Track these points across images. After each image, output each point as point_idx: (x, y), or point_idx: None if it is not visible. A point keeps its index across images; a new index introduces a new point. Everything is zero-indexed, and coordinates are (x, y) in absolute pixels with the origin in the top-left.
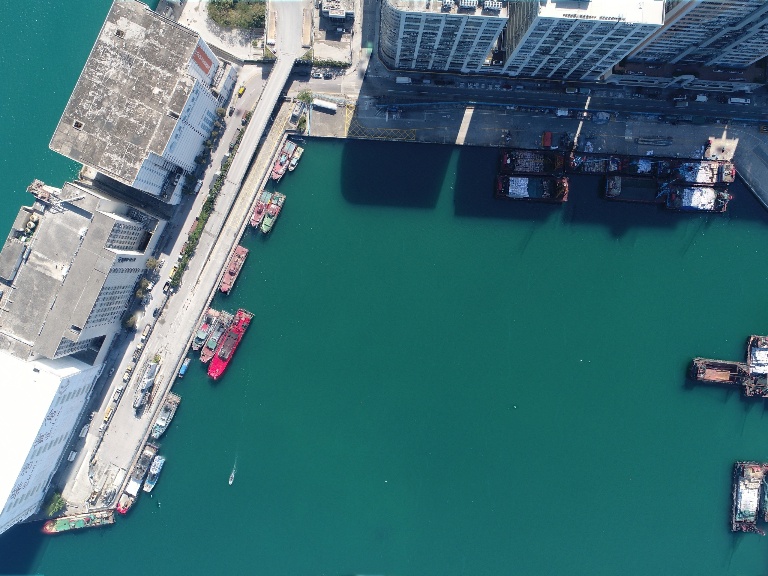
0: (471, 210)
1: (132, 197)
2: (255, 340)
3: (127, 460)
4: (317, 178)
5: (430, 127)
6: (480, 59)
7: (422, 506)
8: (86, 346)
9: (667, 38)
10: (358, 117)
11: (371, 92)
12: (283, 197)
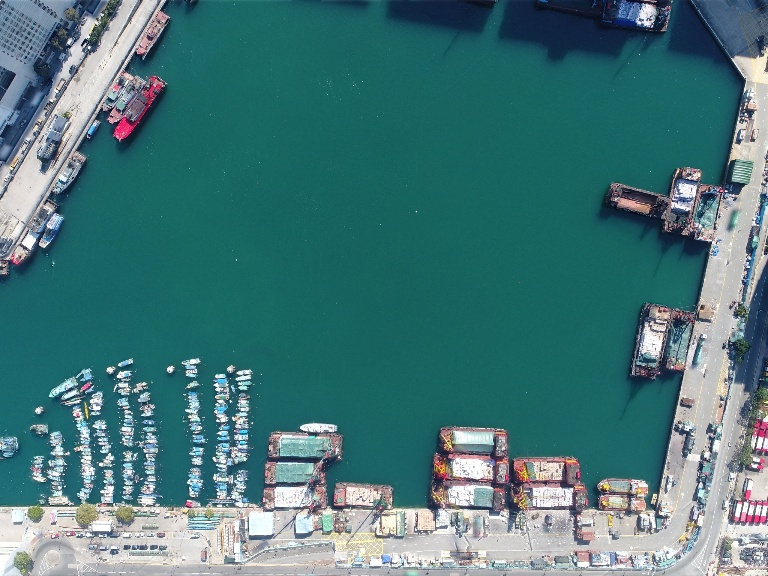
0: (398, 4)
1: None
2: (166, 111)
3: (27, 214)
4: None
5: None
6: None
7: (309, 303)
8: None
9: None
10: None
11: None
12: None
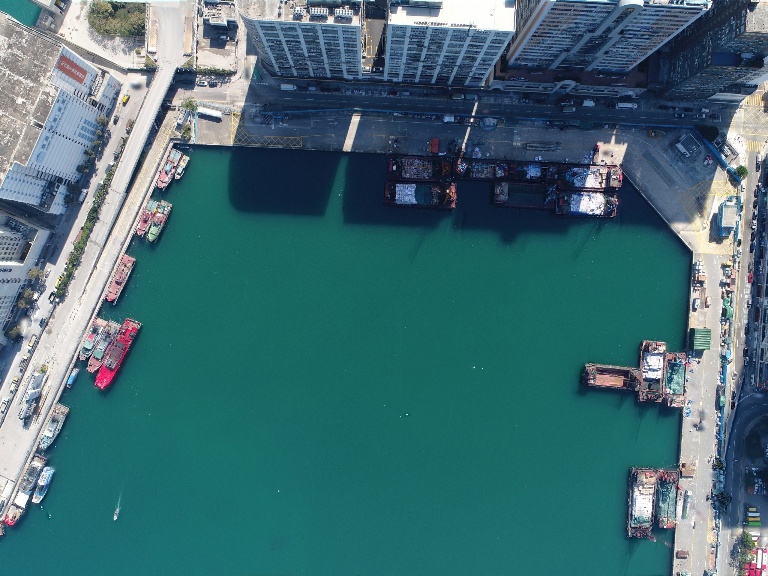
0: (361, 217)
1: (17, 207)
2: (144, 349)
3: (16, 471)
4: (204, 186)
5: (317, 134)
6: (356, 66)
7: (315, 515)
8: None
9: (536, 44)
10: (244, 125)
11: (257, 100)
12: (169, 206)
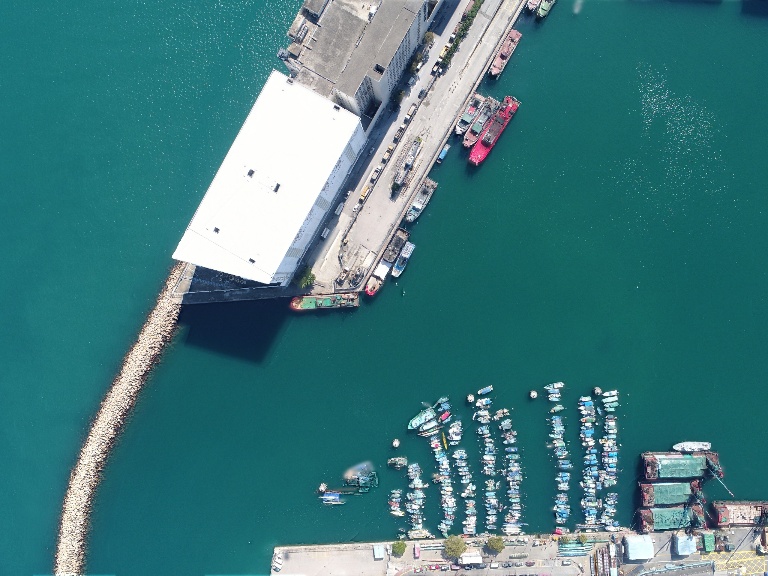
0: (758, 9)
1: None
2: (517, 131)
3: (378, 243)
4: None
5: None
6: None
7: (676, 319)
8: (361, 111)
9: None
10: None
11: None
12: None
